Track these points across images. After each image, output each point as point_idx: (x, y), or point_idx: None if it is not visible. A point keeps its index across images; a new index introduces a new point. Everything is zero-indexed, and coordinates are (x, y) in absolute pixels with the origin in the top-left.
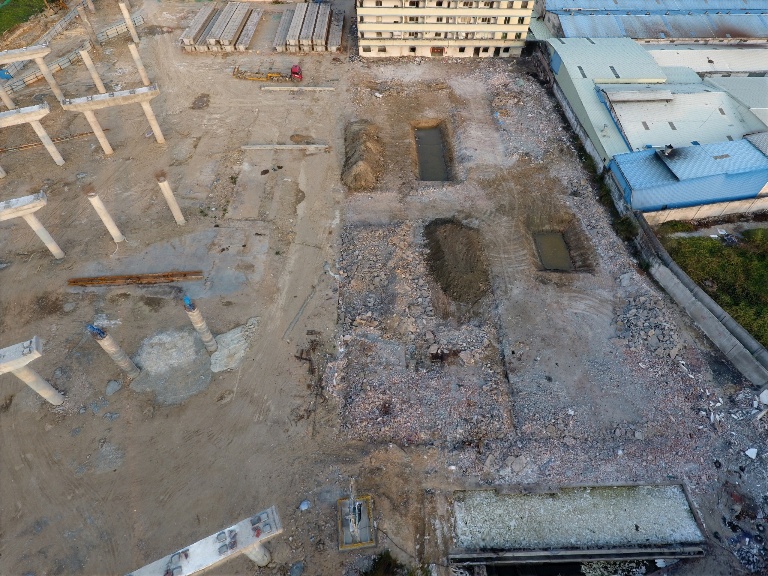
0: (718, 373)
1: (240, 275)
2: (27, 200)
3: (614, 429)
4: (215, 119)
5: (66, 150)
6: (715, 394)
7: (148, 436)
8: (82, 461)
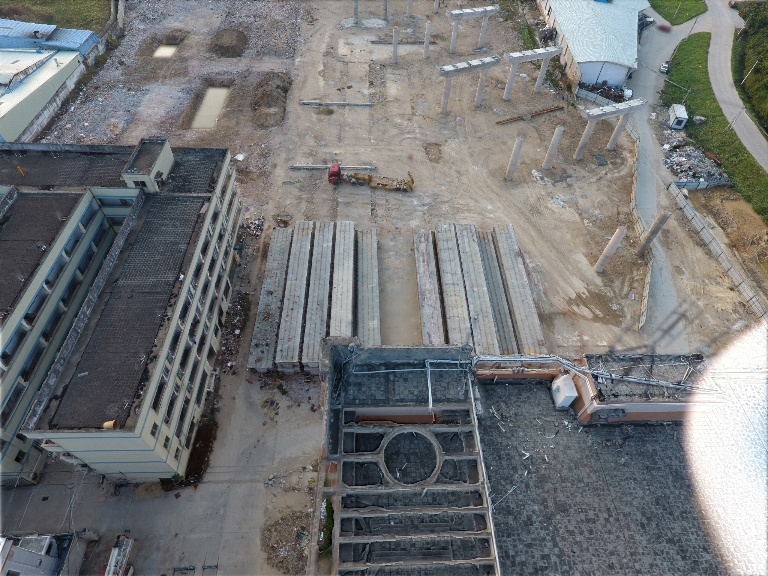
0: (135, 7)
1: (350, 41)
2: (454, 12)
3: (196, 0)
4: (409, 132)
5: (514, 108)
6: (145, 3)
7: (370, 8)
8: (389, 5)
